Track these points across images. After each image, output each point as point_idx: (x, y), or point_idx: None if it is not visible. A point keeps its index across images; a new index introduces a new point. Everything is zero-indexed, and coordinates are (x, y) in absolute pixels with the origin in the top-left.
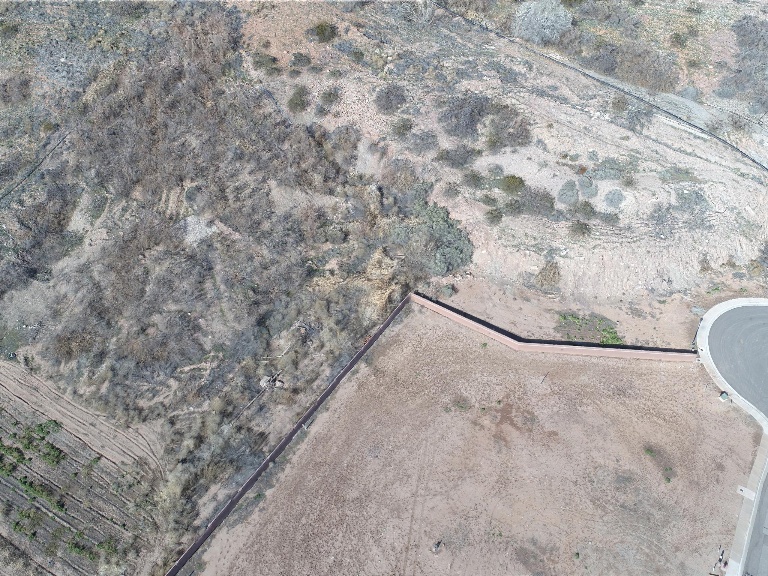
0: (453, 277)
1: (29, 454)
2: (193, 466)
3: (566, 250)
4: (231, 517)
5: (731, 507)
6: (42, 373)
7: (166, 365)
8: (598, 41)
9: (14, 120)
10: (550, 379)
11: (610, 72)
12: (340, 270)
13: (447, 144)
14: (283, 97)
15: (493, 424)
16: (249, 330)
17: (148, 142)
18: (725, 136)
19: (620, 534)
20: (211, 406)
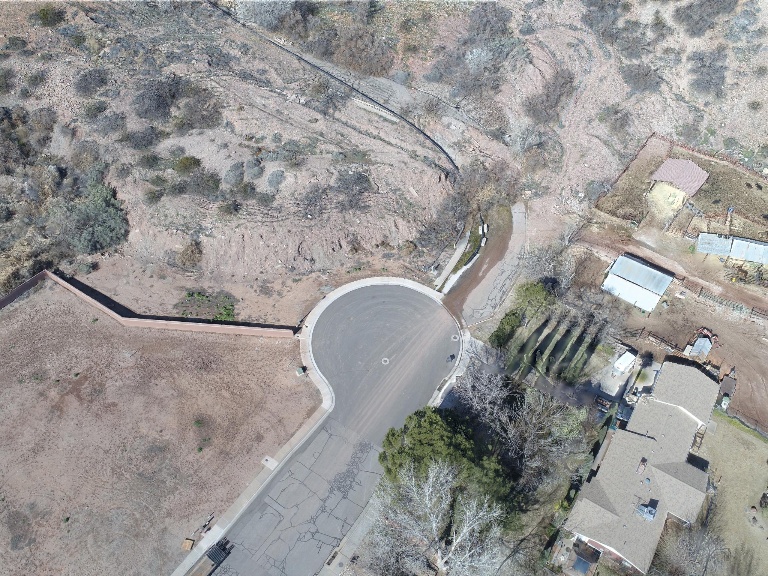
0: (100, 255)
1: None
2: None
3: (211, 229)
4: None
5: (246, 476)
6: None
7: None
8: (328, 26)
9: None
10: (141, 353)
11: (329, 56)
12: None
13: (135, 126)
14: None
15: (58, 395)
16: None
17: None
18: (415, 119)
19: (121, 500)
20: None
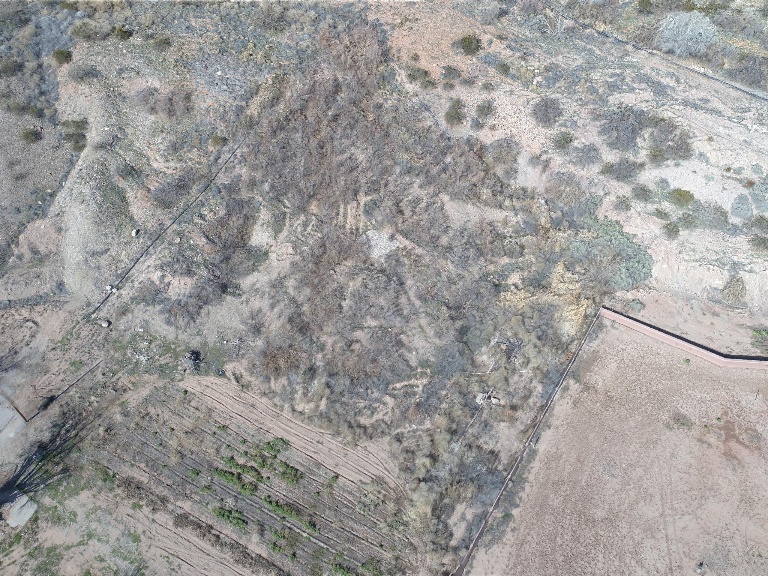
0: (637, 292)
1: (266, 473)
2: (437, 485)
3: (750, 264)
4: (485, 537)
5: None
6: (254, 390)
7: (378, 382)
8: (738, 53)
9: (181, 134)
10: (763, 396)
11: (756, 84)
12: (523, 285)
13: (610, 157)
14: (439, 110)
15: (720, 442)
16: (454, 346)
17: (317, 156)
18: None
19: None
20: (433, 423)
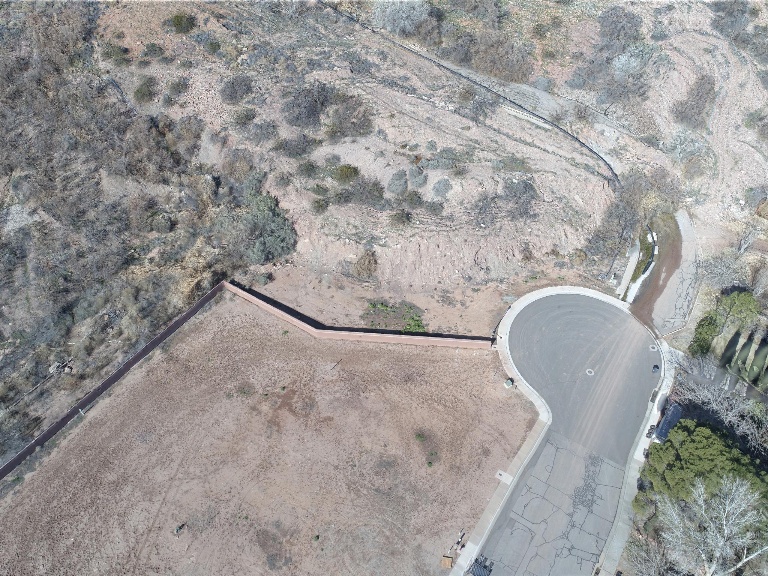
0: (272, 266)
1: None
2: None
3: (385, 239)
4: None
5: (485, 491)
6: None
7: None
8: (460, 32)
9: None
10: (341, 366)
11: (466, 63)
12: (160, 259)
13: (287, 134)
14: (130, 87)
15: (271, 410)
16: (49, 317)
17: None
18: (567, 126)
19: (366, 517)
20: None
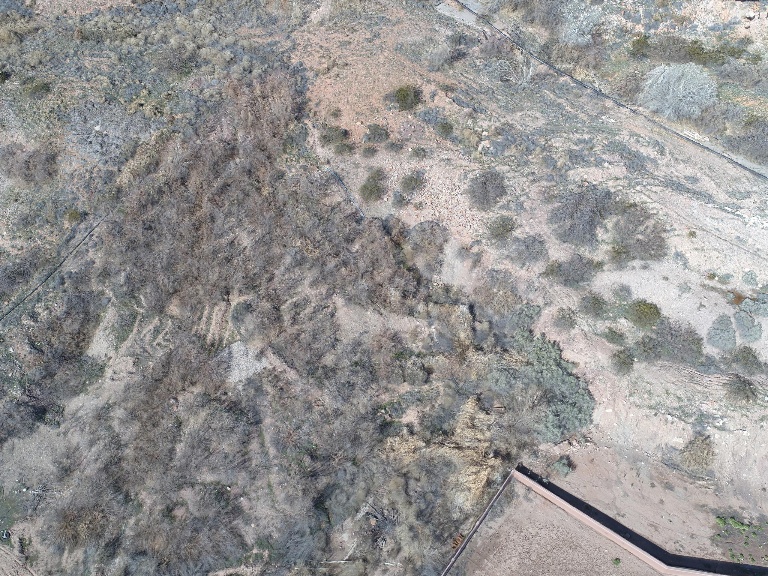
0: (568, 445)
1: None
2: None
3: (723, 419)
4: None
5: None
6: (39, 566)
7: (195, 568)
8: (746, 116)
9: (36, 205)
10: None
11: (764, 158)
12: (421, 426)
13: (559, 254)
14: (354, 182)
15: None
16: (304, 520)
17: (190, 240)
18: None
19: None
20: None
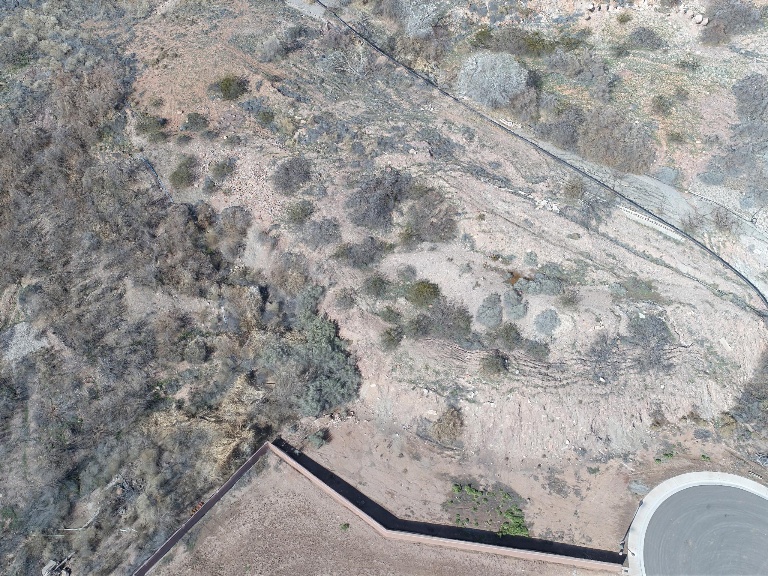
0: (329, 418)
1: None
2: None
3: (474, 392)
4: None
5: None
6: None
7: None
8: (562, 104)
9: None
10: None
11: (571, 145)
12: (191, 401)
13: (351, 236)
14: (166, 169)
15: None
16: (48, 490)
17: None
18: (704, 238)
19: None
20: None
